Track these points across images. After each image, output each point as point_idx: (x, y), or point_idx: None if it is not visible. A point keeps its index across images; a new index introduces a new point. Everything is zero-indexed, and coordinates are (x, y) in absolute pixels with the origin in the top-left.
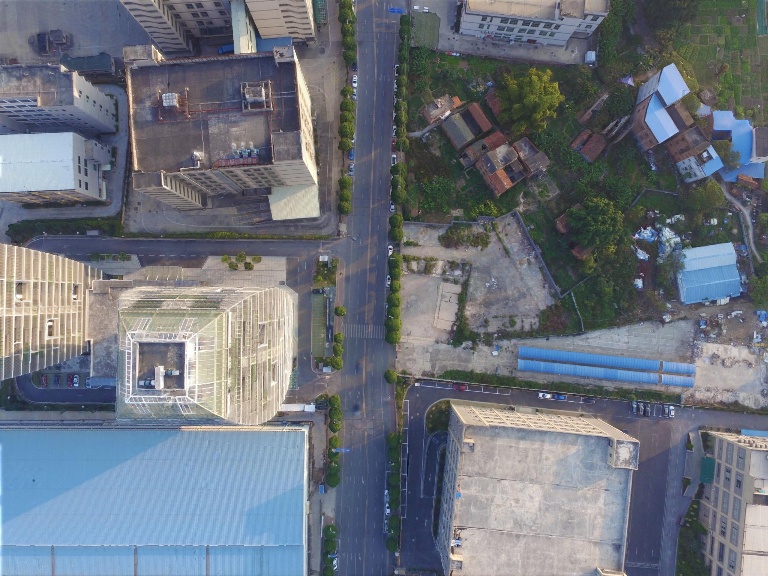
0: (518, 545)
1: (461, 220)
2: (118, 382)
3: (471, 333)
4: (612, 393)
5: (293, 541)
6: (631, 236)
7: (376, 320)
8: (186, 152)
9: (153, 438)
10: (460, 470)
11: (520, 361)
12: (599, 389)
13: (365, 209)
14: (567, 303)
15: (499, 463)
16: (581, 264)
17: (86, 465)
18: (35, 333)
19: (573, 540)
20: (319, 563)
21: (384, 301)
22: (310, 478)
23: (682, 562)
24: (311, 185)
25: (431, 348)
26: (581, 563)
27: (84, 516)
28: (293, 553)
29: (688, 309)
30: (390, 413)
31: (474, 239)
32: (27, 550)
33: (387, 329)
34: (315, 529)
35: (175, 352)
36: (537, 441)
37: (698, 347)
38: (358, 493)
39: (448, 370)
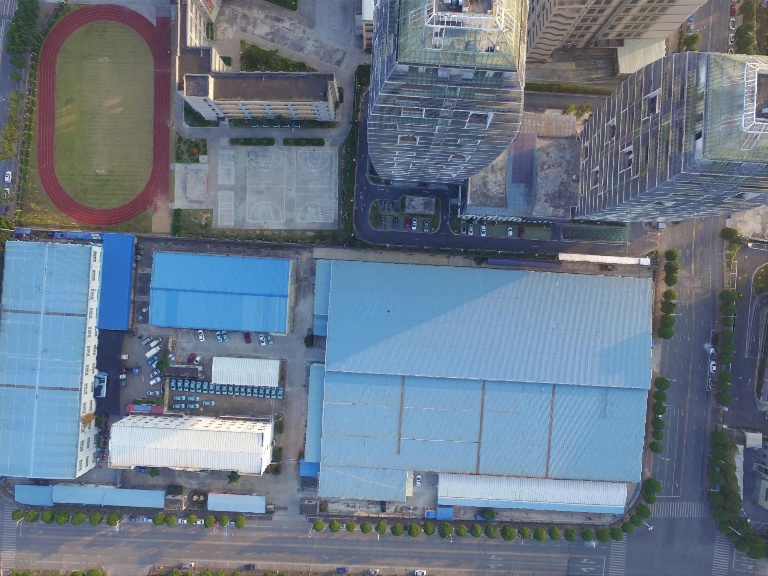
0: None
1: None
2: (709, 122)
3: None
4: None
5: (642, 384)
6: None
7: None
8: None
9: (504, 277)
10: None
11: None
12: None
13: None
14: None
15: None
16: None
17: (439, 299)
18: None
19: None
20: None
21: None
22: None
23: None
24: (661, 40)
25: (762, 211)
26: None
27: (438, 348)
28: (637, 397)
29: None
30: (718, 273)
31: None
32: (378, 379)
33: None
34: None
35: None
36: None
37: None
38: (683, 350)
39: None
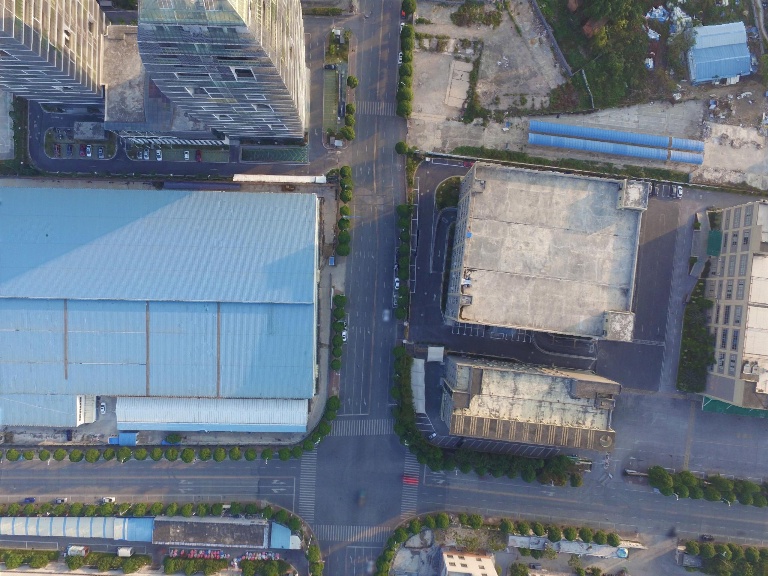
0: (527, 287)
1: None
2: None
3: (482, 109)
4: (621, 171)
5: (304, 298)
6: (643, 16)
7: (387, 97)
8: None
9: (166, 197)
10: (471, 212)
11: (530, 134)
12: (608, 167)
13: None
14: (578, 81)
15: (510, 207)
16: (592, 40)
17: (99, 222)
18: (53, 27)
19: (582, 284)
20: (328, 336)
21: (396, 79)
22: (320, 253)
23: (687, 339)
24: None
25: (442, 125)
26: (589, 306)
27: (97, 270)
28: (303, 313)
29: (698, 90)
30: (400, 190)
31: (486, 17)
32: (40, 304)
33: (399, 99)
34: (325, 303)
35: None
36: (548, 186)
37: (707, 127)
38: (368, 268)
39: (459, 147)
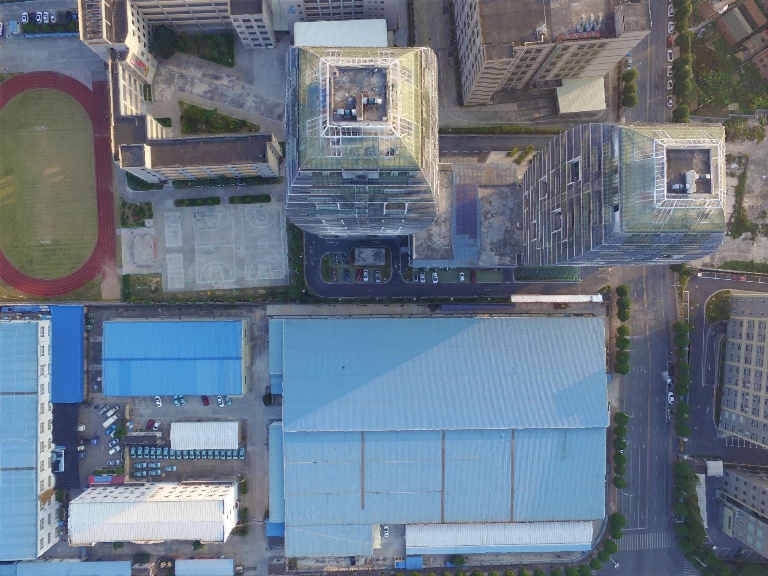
0: None
1: (737, 114)
2: (624, 196)
3: (751, 224)
4: None
5: (599, 423)
6: None
7: None
8: (529, 27)
9: (457, 325)
10: None
11: None
12: None
13: (642, 104)
14: None
15: None
16: None
17: (393, 352)
18: None
19: None
20: None
21: None
22: None
23: None
24: (599, 77)
25: None
26: None
27: (395, 401)
28: (596, 436)
29: None
30: (670, 304)
31: (751, 132)
32: (337, 436)
33: None
34: None
35: (700, 159)
36: None
37: None
38: (641, 383)
39: (728, 261)
